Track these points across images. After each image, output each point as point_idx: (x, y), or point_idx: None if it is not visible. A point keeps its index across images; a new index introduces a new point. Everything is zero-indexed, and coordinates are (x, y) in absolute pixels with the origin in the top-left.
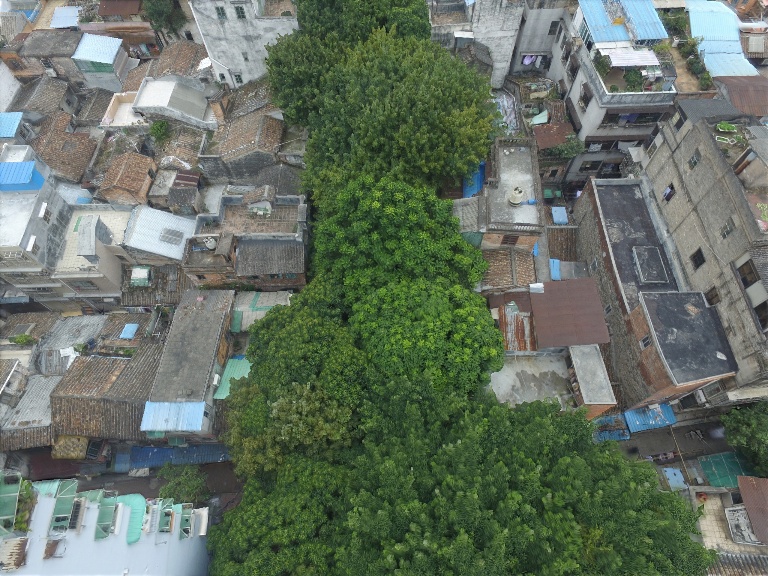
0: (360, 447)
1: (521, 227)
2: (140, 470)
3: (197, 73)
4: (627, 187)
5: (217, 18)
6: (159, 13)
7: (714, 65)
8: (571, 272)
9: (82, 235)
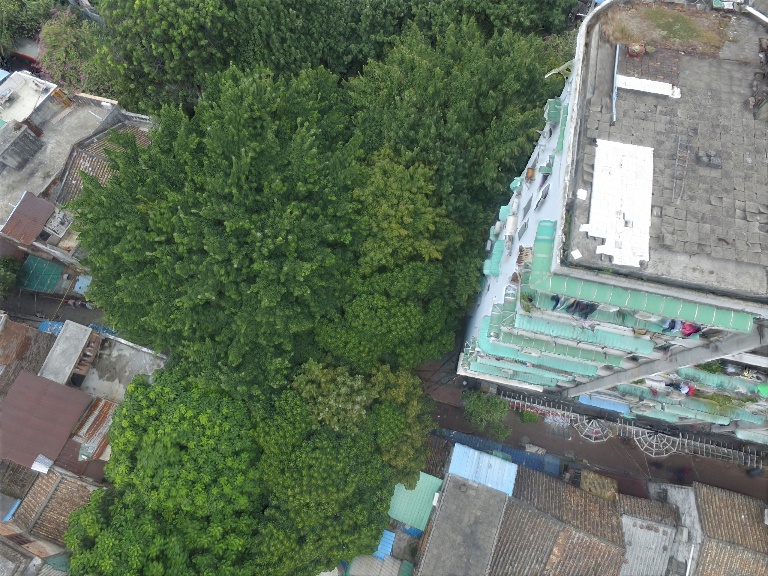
0: (302, 360)
1: None
2: (534, 451)
3: None
4: None
5: None
6: None
7: None
8: None
9: None
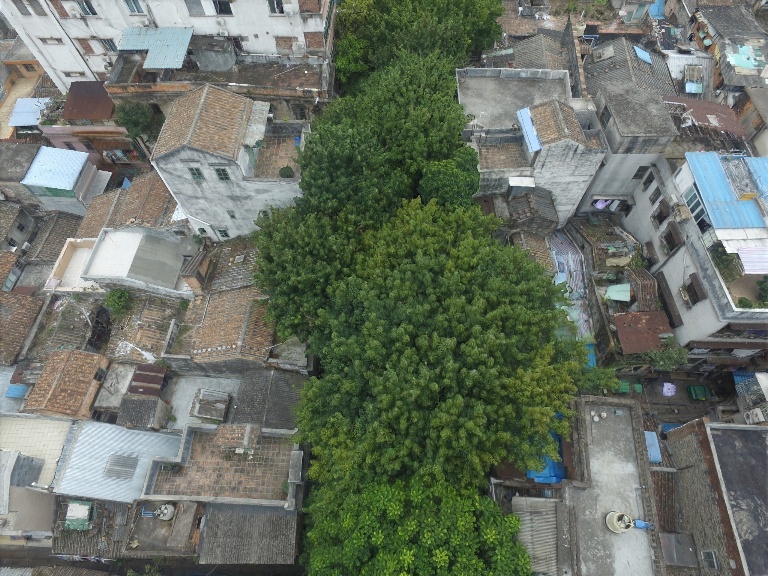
0: None
1: None
2: None
3: (170, 226)
4: (754, 433)
5: (191, 178)
6: (135, 122)
7: None
8: (672, 554)
9: None
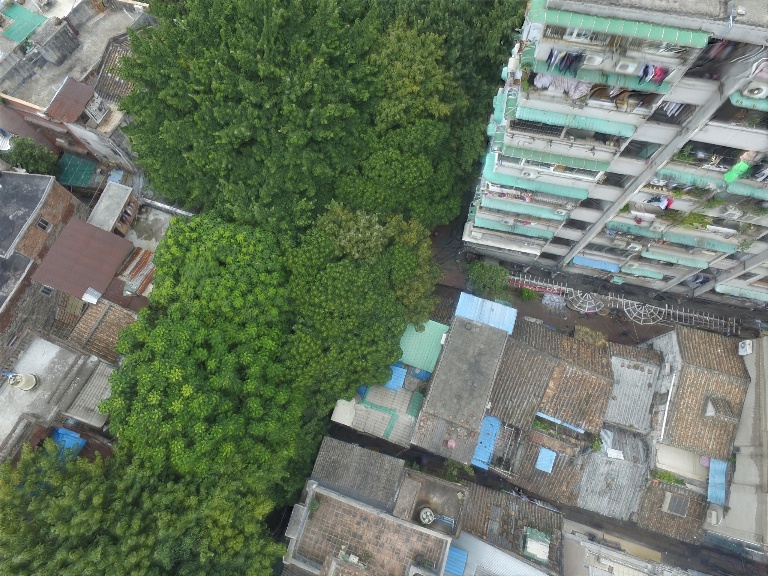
0: None
1: None
2: None
3: None
4: None
5: None
6: None
7: None
8: None
9: None
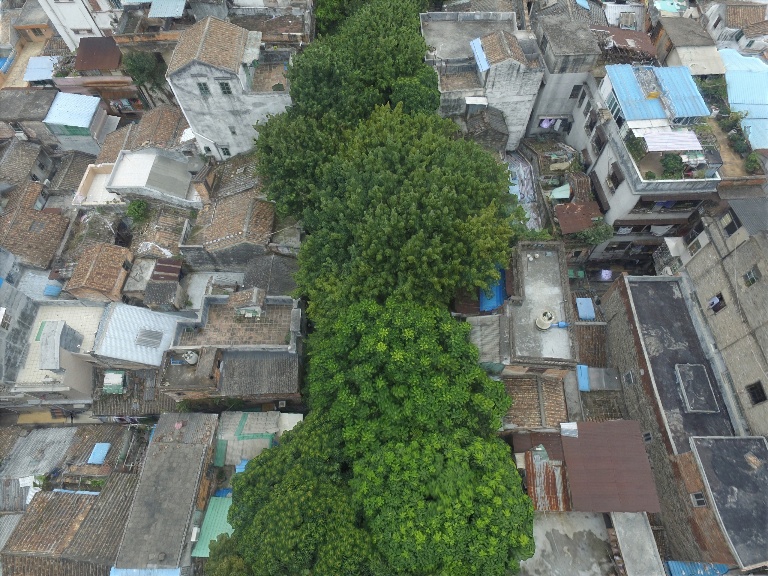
0: None
1: (551, 362)
2: None
3: (179, 146)
4: (664, 284)
5: (199, 94)
6: (140, 69)
7: (755, 134)
8: (601, 382)
9: (45, 346)
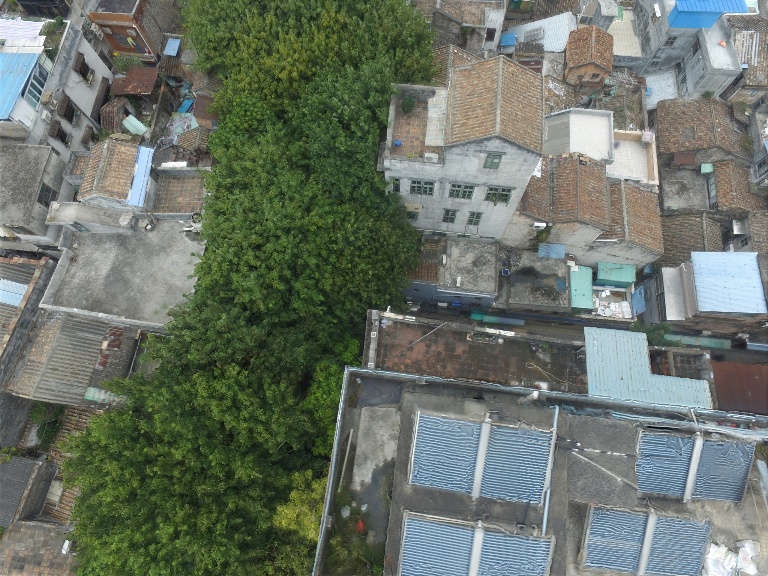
0: None
1: None
2: None
3: None
4: None
5: None
6: None
7: None
8: None
9: (611, 2)
